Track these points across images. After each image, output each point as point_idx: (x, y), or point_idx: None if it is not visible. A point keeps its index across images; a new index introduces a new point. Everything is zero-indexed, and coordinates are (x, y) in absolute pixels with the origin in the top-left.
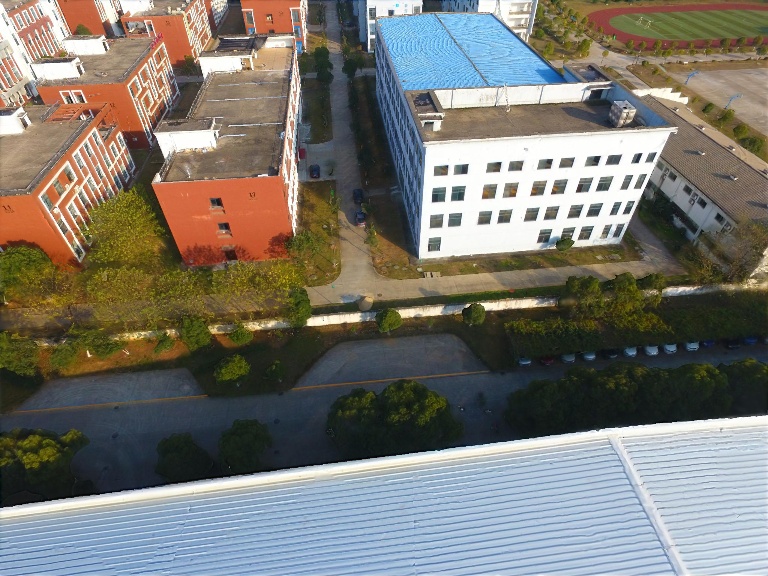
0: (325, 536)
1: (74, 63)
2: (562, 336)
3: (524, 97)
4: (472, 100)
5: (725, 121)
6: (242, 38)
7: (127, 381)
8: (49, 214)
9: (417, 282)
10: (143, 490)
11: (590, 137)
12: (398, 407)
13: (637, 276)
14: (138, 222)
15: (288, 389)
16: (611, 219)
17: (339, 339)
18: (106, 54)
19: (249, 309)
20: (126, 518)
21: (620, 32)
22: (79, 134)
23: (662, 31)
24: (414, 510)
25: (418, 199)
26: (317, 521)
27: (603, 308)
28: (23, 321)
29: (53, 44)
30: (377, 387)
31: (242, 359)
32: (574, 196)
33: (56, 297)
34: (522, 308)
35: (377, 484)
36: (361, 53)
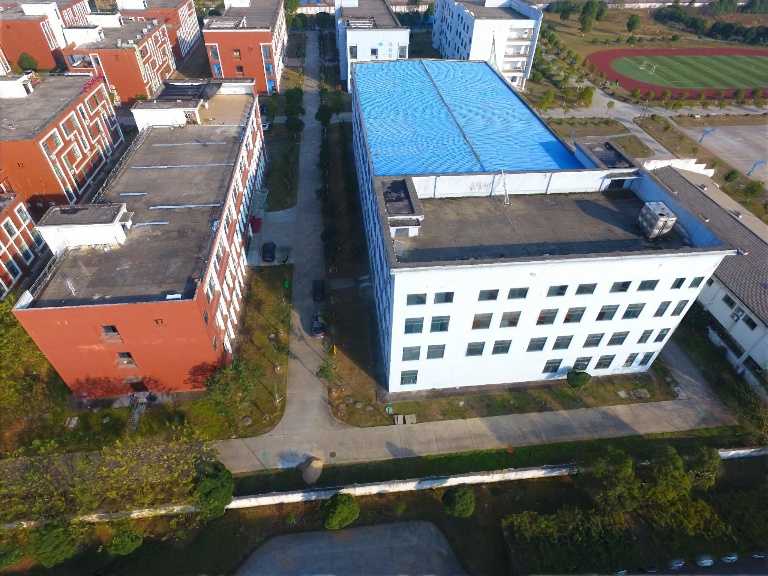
0: None
1: None
2: (582, 546)
3: (527, 185)
4: (461, 188)
5: (753, 194)
6: (192, 84)
7: None
8: None
9: (384, 432)
10: None
11: (620, 262)
12: None
13: (673, 427)
14: (3, 351)
15: None
16: (638, 347)
17: (270, 532)
18: (27, 98)
19: None
20: None
21: (623, 77)
22: None
23: (668, 77)
24: None
25: (388, 322)
26: None
27: (638, 500)
28: None
29: None
30: None
31: None
32: (593, 324)
33: None
34: (524, 478)
35: None
36: (340, 94)
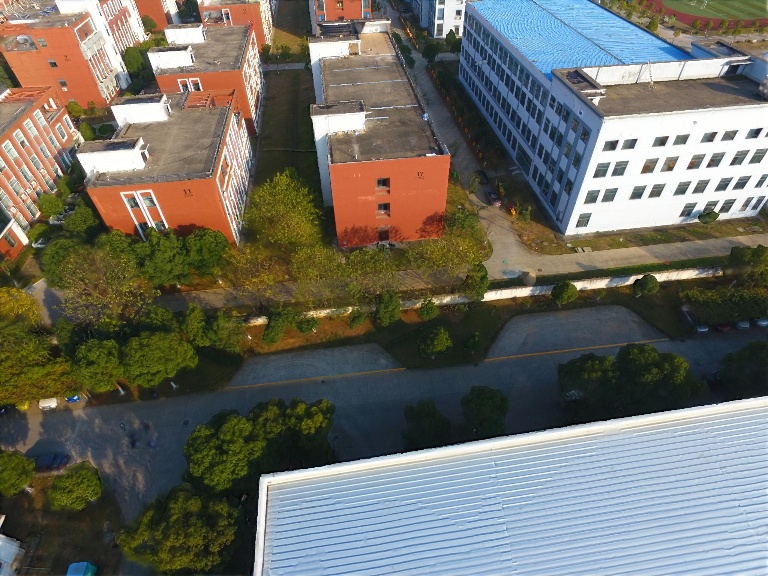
0: (640, 483)
1: (188, 51)
2: (740, 303)
3: (665, 74)
4: (615, 77)
5: None
6: (340, 24)
7: (323, 357)
8: (222, 198)
9: (572, 257)
10: (445, 448)
11: (759, 109)
12: (647, 368)
13: None
14: (303, 204)
15: (481, 360)
16: (754, 192)
17: (513, 313)
18: (205, 42)
19: (418, 286)
20: (436, 474)
21: (678, 13)
22: (226, 120)
23: (719, 11)
24: (715, 458)
25: (572, 176)
26: (626, 470)
27: None
28: (201, 303)
29: (131, 35)
30: (566, 356)
31: (446, 331)
32: (727, 169)
33: (265, 275)
34: (681, 279)
35: (667, 436)
36: (428, 38)
